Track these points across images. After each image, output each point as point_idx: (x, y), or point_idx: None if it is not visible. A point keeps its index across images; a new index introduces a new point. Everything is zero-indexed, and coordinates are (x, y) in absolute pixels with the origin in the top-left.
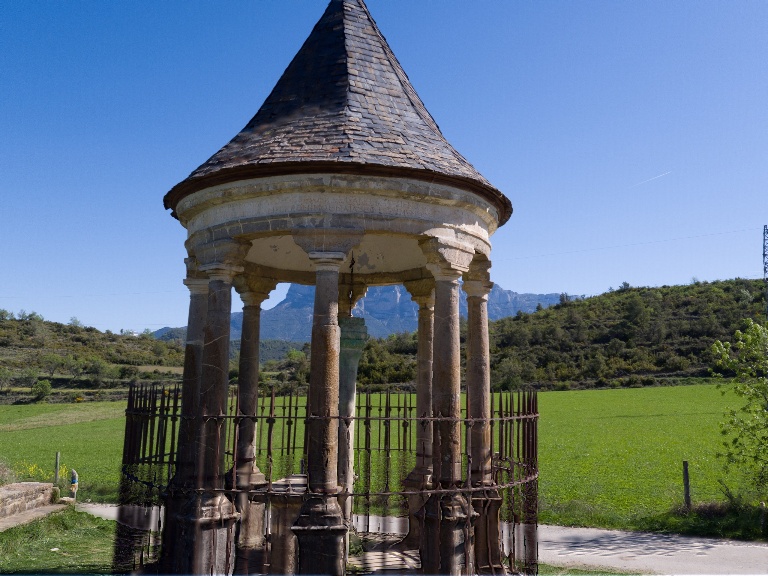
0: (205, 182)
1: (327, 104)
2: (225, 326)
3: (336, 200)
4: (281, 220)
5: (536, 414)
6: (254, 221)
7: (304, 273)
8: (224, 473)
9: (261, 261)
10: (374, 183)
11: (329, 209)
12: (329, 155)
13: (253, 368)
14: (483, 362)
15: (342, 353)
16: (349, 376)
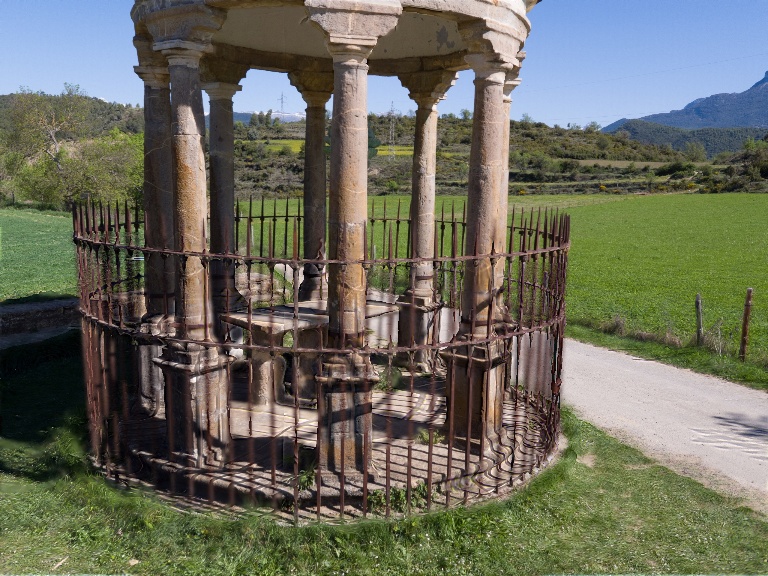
0: None
1: None
2: (157, 138)
3: None
4: (142, 6)
5: (483, 255)
6: (134, 11)
7: (376, 62)
8: (171, 292)
9: (319, 53)
10: None
11: None
12: None
13: (314, 178)
14: (481, 175)
15: None
16: None
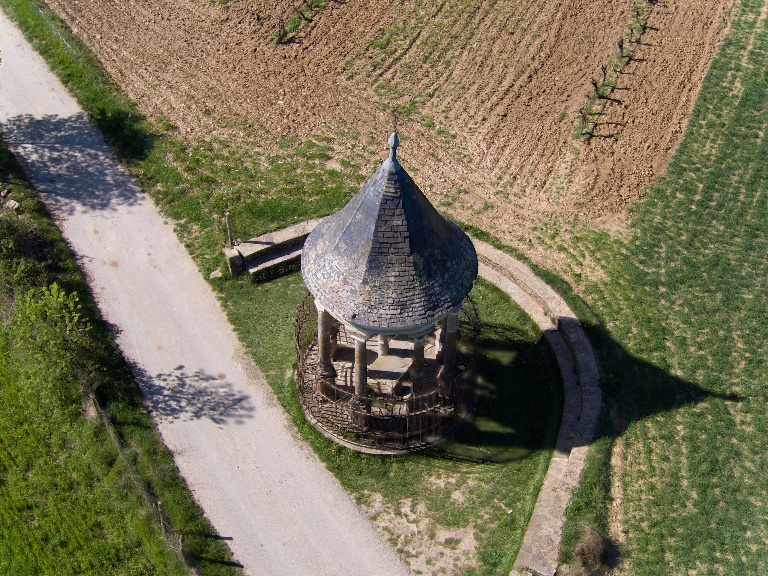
0: None
1: None
2: None
3: None
4: None
5: None
6: None
7: None
8: None
9: None
10: None
11: None
12: None
13: None
14: None
15: None
16: None
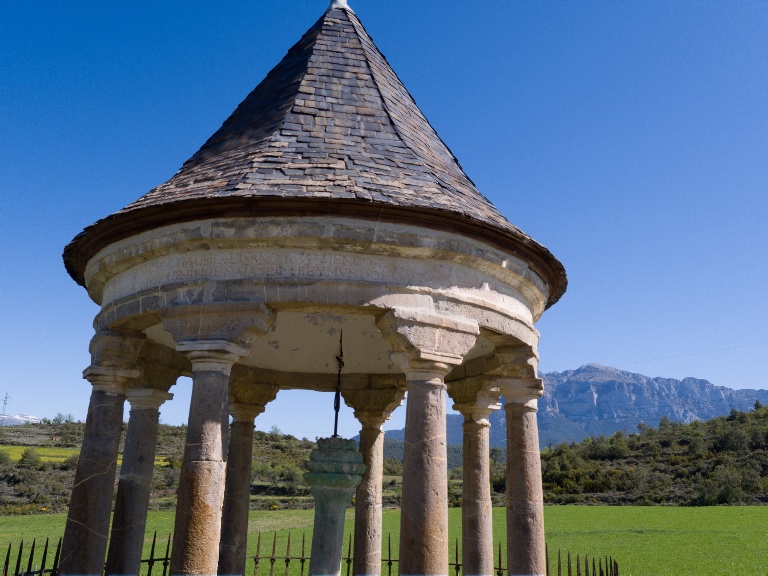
0: (83, 253)
1: (258, 133)
2: (102, 459)
3: (225, 259)
4: (152, 296)
5: None
6: (126, 301)
7: (317, 376)
8: None
9: (255, 362)
10: (277, 228)
11: (214, 274)
12: (207, 191)
13: (237, 508)
14: (529, 512)
15: (317, 493)
16: (327, 529)
